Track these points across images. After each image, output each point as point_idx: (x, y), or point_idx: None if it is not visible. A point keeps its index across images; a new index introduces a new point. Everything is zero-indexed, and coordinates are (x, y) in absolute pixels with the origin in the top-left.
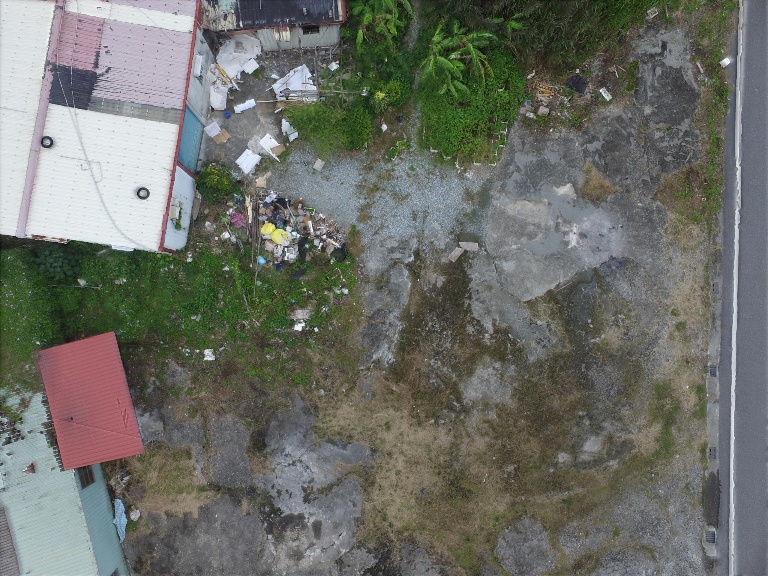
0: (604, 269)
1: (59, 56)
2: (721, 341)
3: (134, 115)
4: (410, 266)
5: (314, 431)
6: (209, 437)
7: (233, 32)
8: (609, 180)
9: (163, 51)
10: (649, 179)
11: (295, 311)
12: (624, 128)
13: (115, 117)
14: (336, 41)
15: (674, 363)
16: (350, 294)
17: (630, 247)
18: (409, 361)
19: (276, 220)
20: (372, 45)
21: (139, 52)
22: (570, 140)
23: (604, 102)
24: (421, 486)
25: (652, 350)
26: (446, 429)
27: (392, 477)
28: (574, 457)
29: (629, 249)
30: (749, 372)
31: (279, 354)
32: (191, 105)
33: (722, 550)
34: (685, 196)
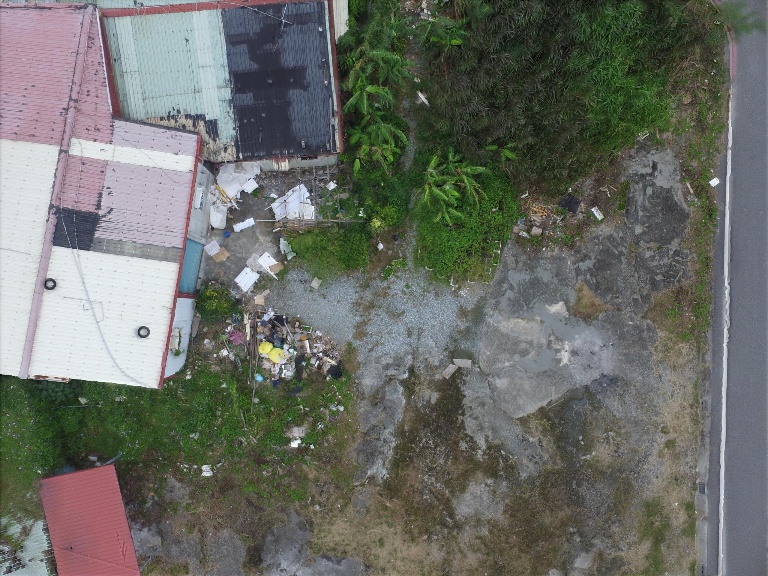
0: (595, 386)
1: (63, 199)
2: (710, 458)
3: (135, 255)
4: (405, 383)
5: (309, 546)
6: (206, 552)
7: (233, 163)
8: (600, 298)
9: (164, 191)
10: (640, 298)
11: (291, 429)
12: (615, 247)
13: (117, 257)
14: (334, 163)
15: (663, 480)
16: (346, 410)
17: (621, 365)
18: (403, 477)
19: (274, 339)
20: (369, 170)
21: (141, 193)
22: (562, 259)
23: (596, 221)
24: None
25: (642, 467)
26: (439, 545)
27: None
28: (565, 573)
29: (620, 367)
30: (737, 490)
31: (275, 470)
32: (191, 235)
33: None
34: (675, 315)
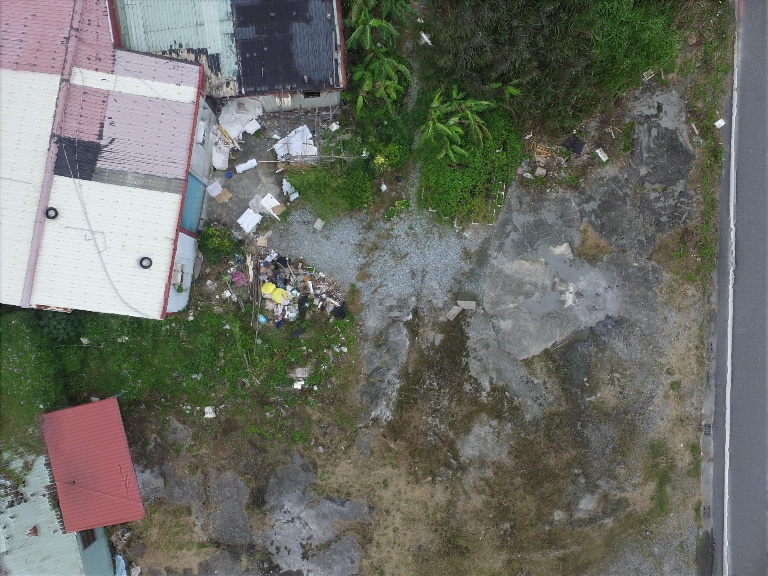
0: (600, 328)
1: (64, 128)
2: (715, 400)
3: (137, 185)
4: (408, 324)
5: (313, 488)
6: (209, 494)
7: (235, 98)
8: (605, 240)
9: (166, 122)
10: (645, 239)
11: (295, 369)
12: (620, 188)
13: (119, 187)
14: (337, 103)
15: (669, 422)
16: (349, 352)
17: (626, 306)
18: (407, 419)
19: (276, 280)
20: (372, 108)
21: (143, 123)
22: (567, 200)
23: (600, 163)
24: (418, 543)
25: (647, 409)
26: (443, 486)
27: (390, 534)
28: (570, 515)
29: (625, 308)
30: (743, 431)
31: (279, 412)
32: (193, 171)
33: None
34: (680, 256)
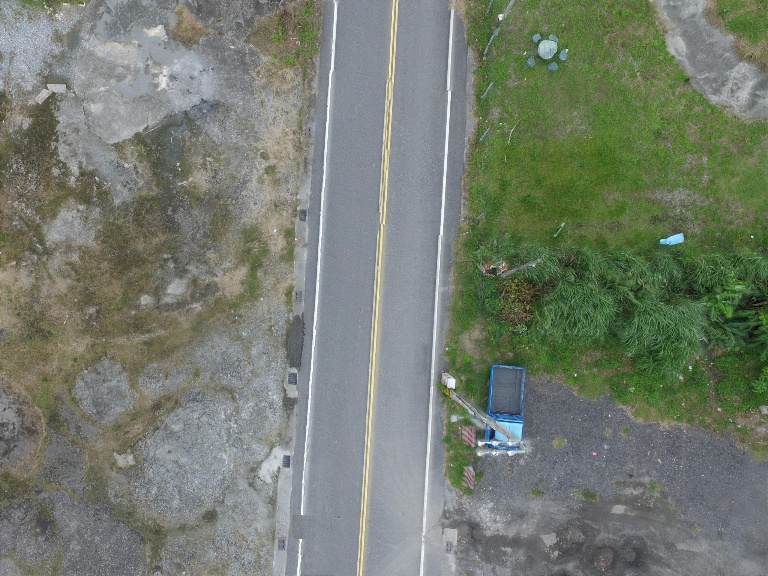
0: (194, 112)
1: None
2: (311, 185)
3: None
4: None
5: None
6: None
7: None
8: (201, 22)
9: None
10: (242, 21)
11: None
12: None
13: None
14: None
15: (262, 207)
16: None
17: (221, 90)
18: None
19: None
20: None
21: None
22: None
23: None
24: (0, 327)
25: (240, 194)
26: (28, 271)
27: None
28: (157, 299)
29: (220, 92)
30: (337, 216)
31: None
32: None
33: (303, 391)
34: (278, 39)
